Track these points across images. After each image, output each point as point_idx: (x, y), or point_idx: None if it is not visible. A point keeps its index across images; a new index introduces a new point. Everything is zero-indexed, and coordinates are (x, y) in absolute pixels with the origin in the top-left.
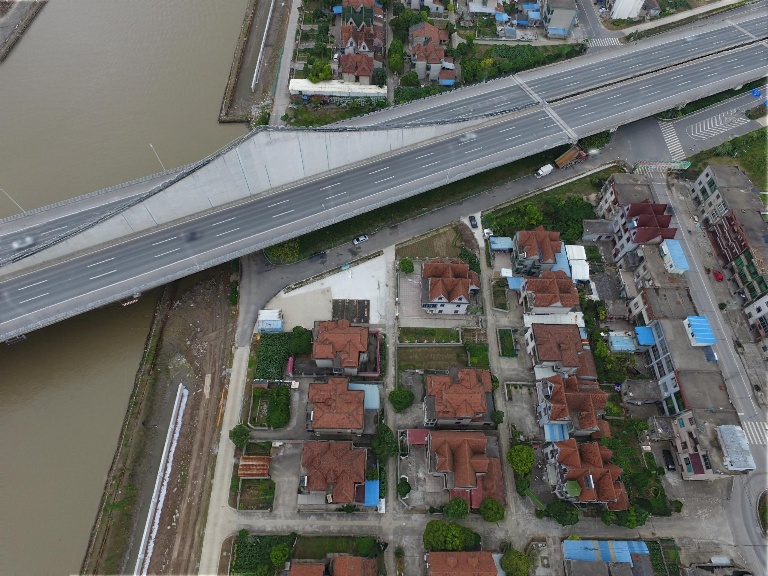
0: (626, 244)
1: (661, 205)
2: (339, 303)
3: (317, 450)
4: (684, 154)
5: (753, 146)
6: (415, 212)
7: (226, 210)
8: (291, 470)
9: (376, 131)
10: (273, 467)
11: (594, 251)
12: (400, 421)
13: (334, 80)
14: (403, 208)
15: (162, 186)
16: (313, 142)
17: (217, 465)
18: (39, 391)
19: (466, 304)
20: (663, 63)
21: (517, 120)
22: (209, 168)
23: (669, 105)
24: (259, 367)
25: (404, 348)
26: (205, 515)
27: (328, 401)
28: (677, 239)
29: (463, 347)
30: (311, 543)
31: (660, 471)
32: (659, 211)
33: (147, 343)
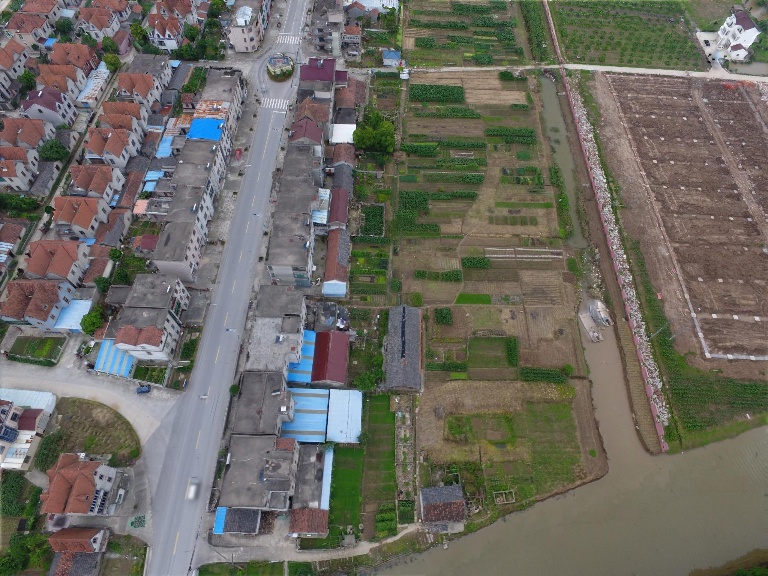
0: None
1: None
2: None
3: None
4: None
5: None
6: None
7: None
8: None
9: None
10: (3, 39)
11: None
12: None
13: None
14: None
15: None
16: None
17: None
18: None
19: None
20: None
21: None
22: None
23: None
24: (11, 5)
25: None
26: None
27: (33, 0)
28: None
29: None
30: None
31: None
32: None
33: None
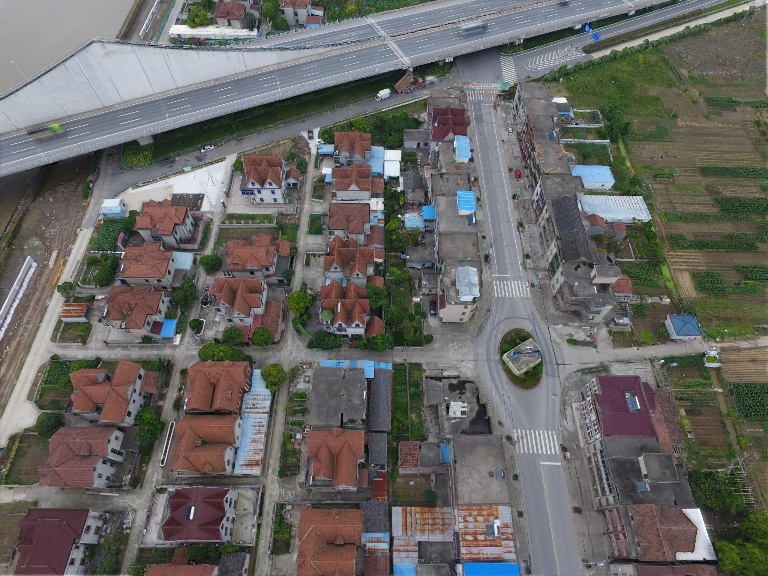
0: (431, 144)
1: (459, 109)
2: (177, 196)
3: (118, 289)
4: (516, 81)
5: (580, 74)
6: (259, 127)
7: (81, 119)
8: None
9: (214, 52)
10: (93, 314)
11: (413, 156)
12: (209, 281)
13: None
14: (251, 125)
15: (13, 90)
16: (151, 57)
17: (47, 313)
18: None
19: (277, 189)
20: (509, 6)
21: (359, 51)
22: (53, 75)
23: (504, 39)
24: (96, 242)
25: (226, 229)
26: (29, 348)
27: (137, 257)
28: (490, 147)
29: (277, 228)
30: (113, 366)
31: (422, 315)
32: (459, 115)
33: (7, 227)
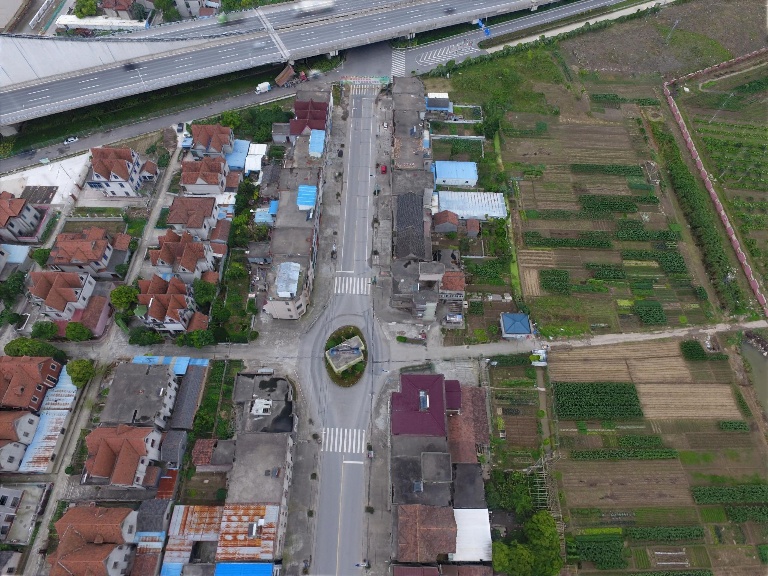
0: None
1: (321, 103)
2: (30, 189)
3: None
4: (404, 76)
5: (470, 69)
6: (128, 119)
7: None
8: None
9: (74, 42)
10: None
11: (281, 150)
12: None
13: (100, 16)
14: (121, 117)
15: None
16: (2, 47)
17: None
18: None
19: (124, 182)
20: (407, 0)
21: (240, 43)
22: None
23: (393, 33)
24: None
25: (73, 222)
26: None
27: None
28: (362, 142)
29: None
30: None
31: (253, 311)
32: (322, 109)
33: None
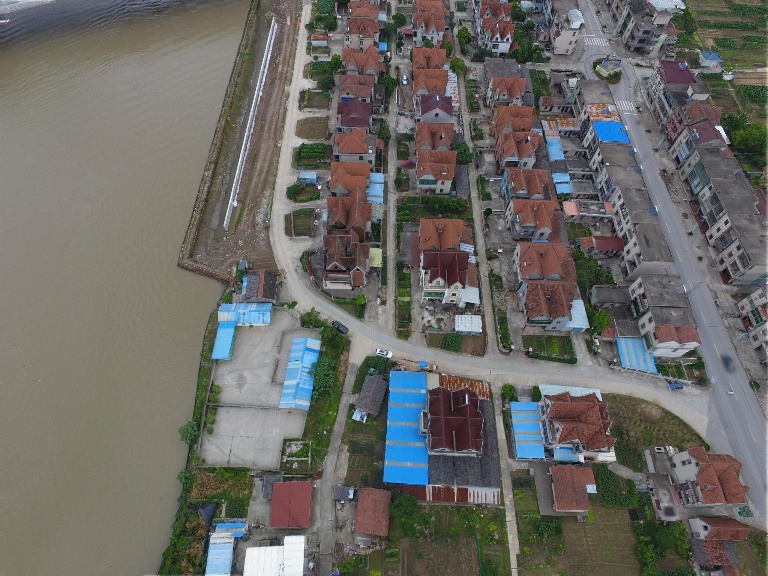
0: None
1: None
2: None
3: None
4: None
5: None
6: None
7: None
8: (339, 44)
9: None
10: (329, 43)
11: None
12: (398, 31)
13: None
14: None
15: None
16: None
17: (298, 42)
18: (185, 43)
19: None
20: None
21: None
22: None
23: None
24: (318, 10)
25: (401, 7)
26: (294, 57)
27: (359, 5)
28: None
29: None
30: None
31: (541, 49)
32: None
33: (252, 3)
